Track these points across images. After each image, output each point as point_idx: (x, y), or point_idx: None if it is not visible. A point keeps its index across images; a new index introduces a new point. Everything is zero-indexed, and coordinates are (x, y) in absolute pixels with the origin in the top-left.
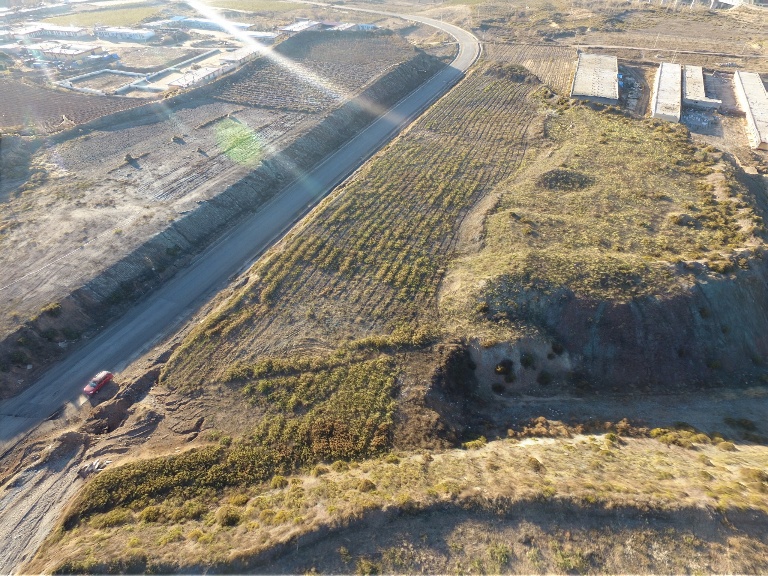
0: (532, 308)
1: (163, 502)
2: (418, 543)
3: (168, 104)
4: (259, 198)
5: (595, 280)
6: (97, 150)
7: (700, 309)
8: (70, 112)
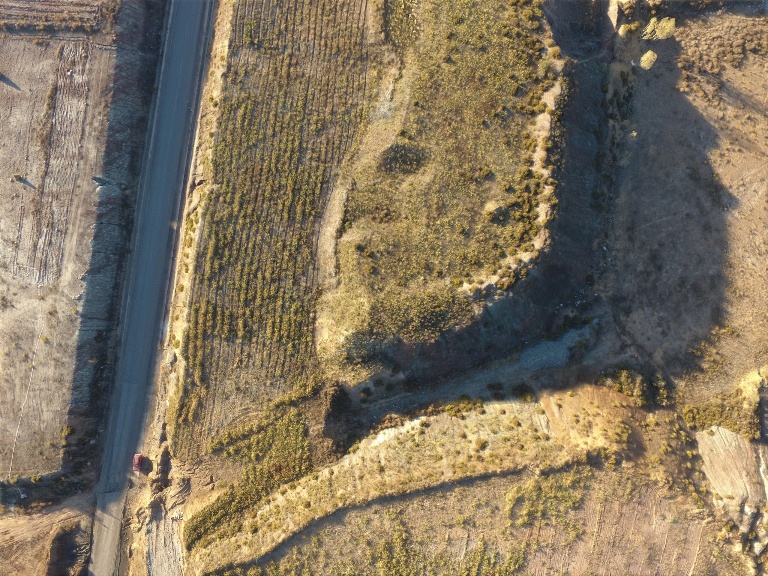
0: (377, 353)
1: (221, 527)
2: (333, 525)
3: None
4: (123, 231)
5: (417, 324)
6: None
7: (484, 325)
8: None
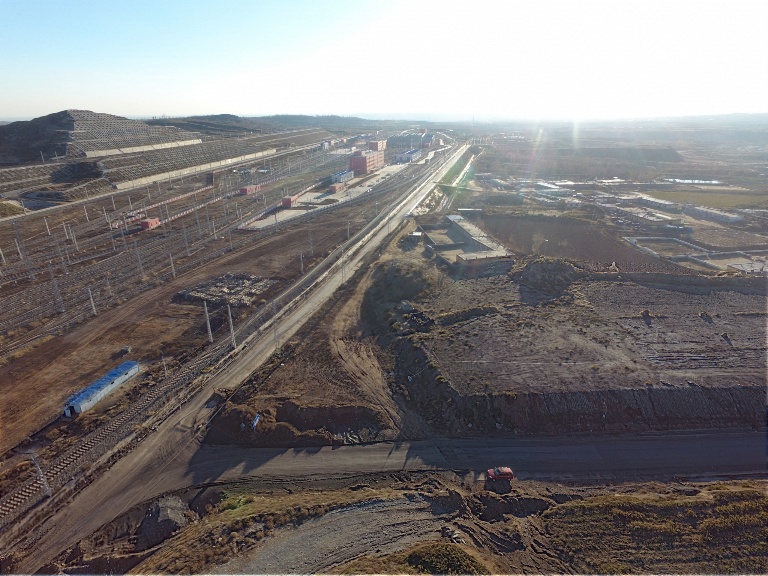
0: None
1: None
2: None
3: (717, 282)
4: None
5: None
6: (622, 297)
7: None
8: (620, 261)
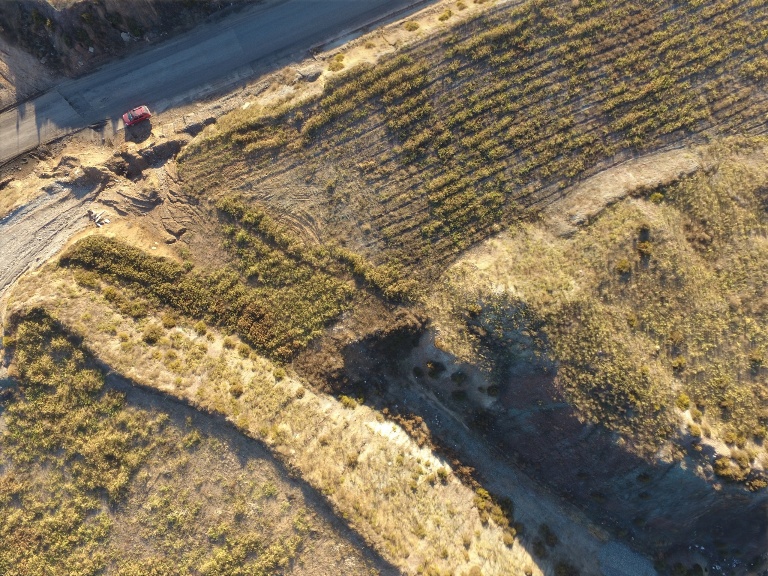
0: (510, 351)
1: (123, 288)
2: (232, 449)
3: None
4: None
5: (592, 382)
6: None
7: (643, 475)
8: None
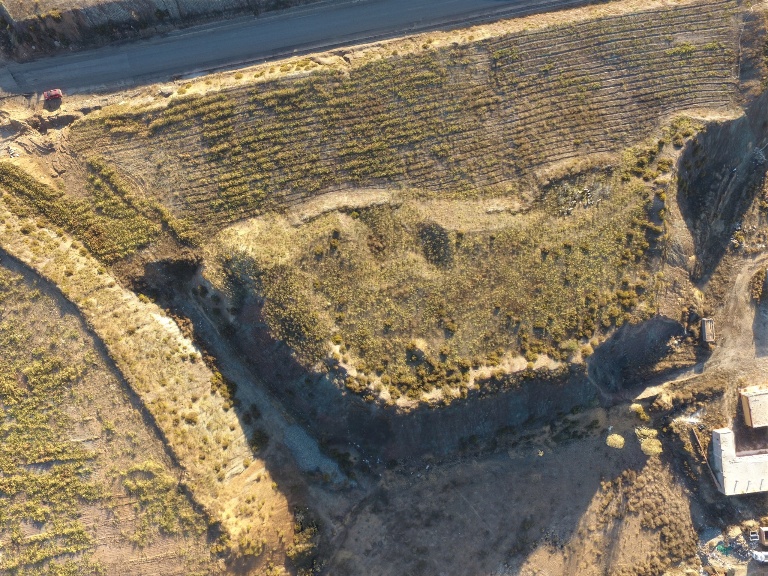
0: (242, 287)
1: (17, 198)
2: (57, 305)
3: None
4: (274, 1)
5: (283, 314)
6: None
7: (307, 379)
8: None
